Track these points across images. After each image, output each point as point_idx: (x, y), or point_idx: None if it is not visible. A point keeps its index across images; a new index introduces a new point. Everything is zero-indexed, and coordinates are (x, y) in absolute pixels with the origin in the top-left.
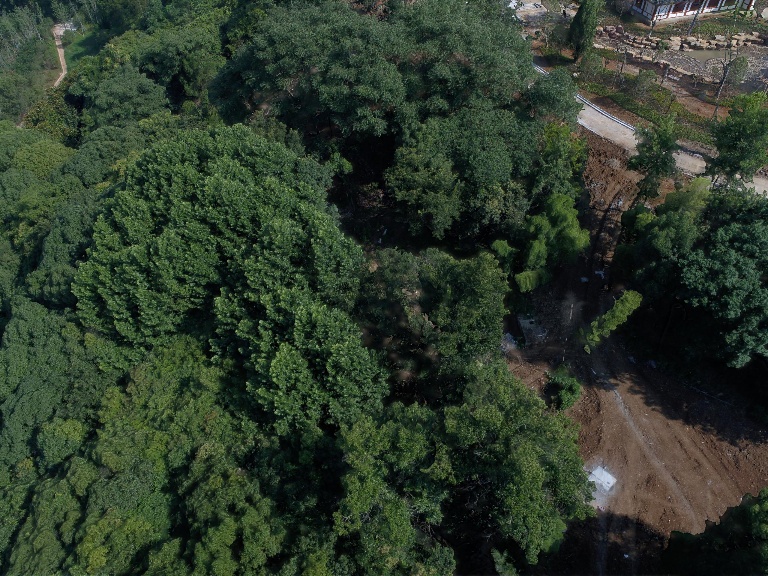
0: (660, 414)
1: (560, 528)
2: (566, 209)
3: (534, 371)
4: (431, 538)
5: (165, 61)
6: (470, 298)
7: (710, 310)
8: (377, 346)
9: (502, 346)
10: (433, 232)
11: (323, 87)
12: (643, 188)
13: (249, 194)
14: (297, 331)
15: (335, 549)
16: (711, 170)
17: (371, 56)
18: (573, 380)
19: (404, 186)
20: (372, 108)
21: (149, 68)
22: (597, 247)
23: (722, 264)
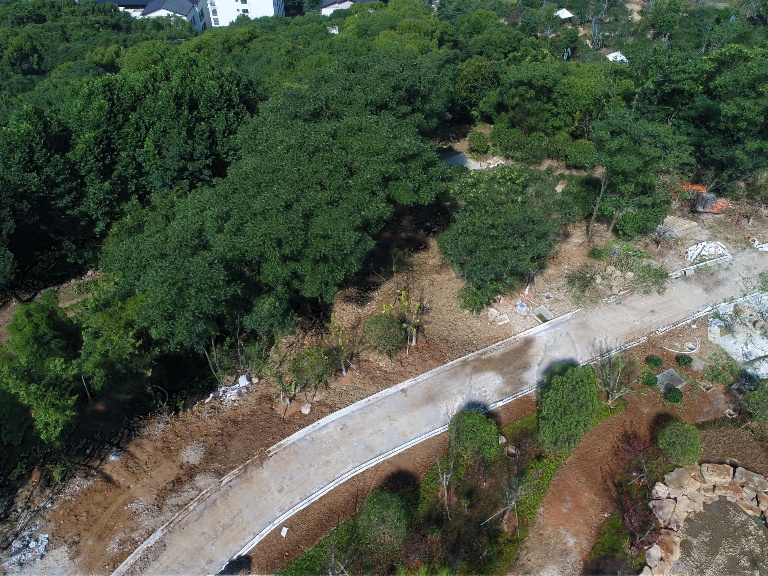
0: None
1: None
2: None
3: None
4: None
5: None
6: None
7: None
8: None
9: None
10: None
11: None
12: None
13: None
14: None
15: None
16: None
17: None
18: None
19: None
20: None
21: None
22: (71, 436)
23: None
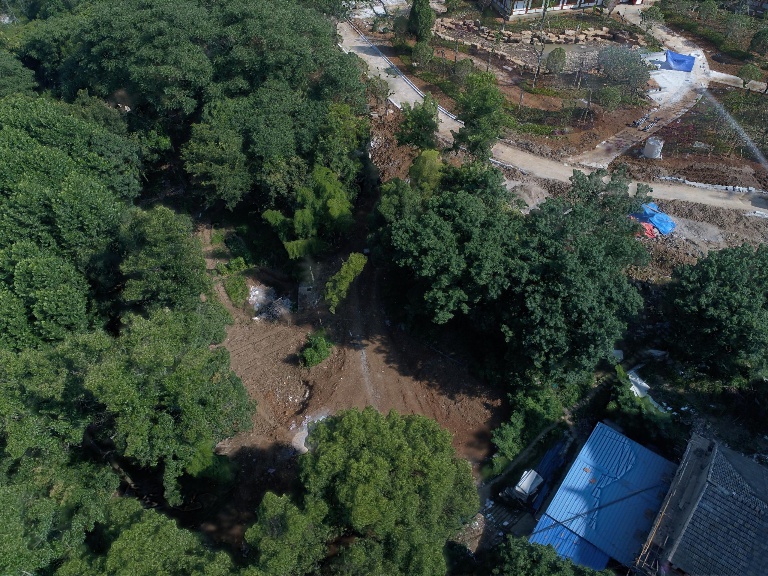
0: (395, 371)
1: (205, 454)
2: (329, 181)
3: (298, 333)
4: (109, 467)
5: (44, 47)
6: (150, 248)
7: (412, 269)
8: (105, 298)
9: (276, 310)
10: (227, 204)
11: (133, 67)
12: (416, 164)
13: (19, 160)
14: (18, 280)
15: (9, 472)
16: (455, 145)
17: (176, 38)
18: (320, 339)
19: (196, 160)
20: (187, 88)
21: (31, 54)
22: None
23: (424, 227)
